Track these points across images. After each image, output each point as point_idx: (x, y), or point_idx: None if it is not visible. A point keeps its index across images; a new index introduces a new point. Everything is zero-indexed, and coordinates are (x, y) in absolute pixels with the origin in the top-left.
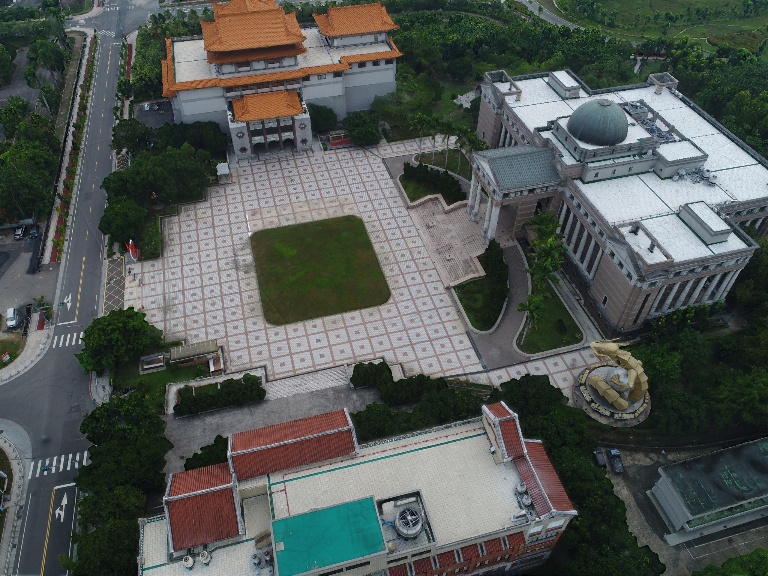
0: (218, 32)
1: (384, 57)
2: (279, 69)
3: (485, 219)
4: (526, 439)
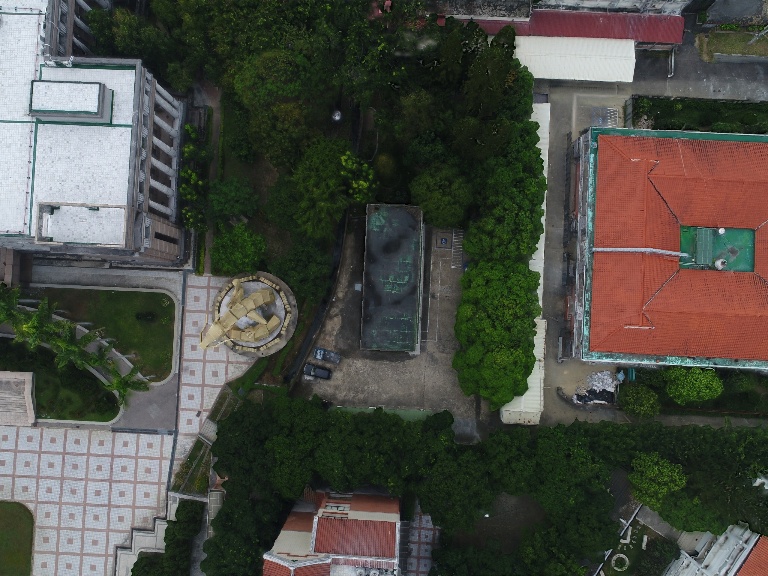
0: None
1: None
2: None
3: None
4: (313, 543)
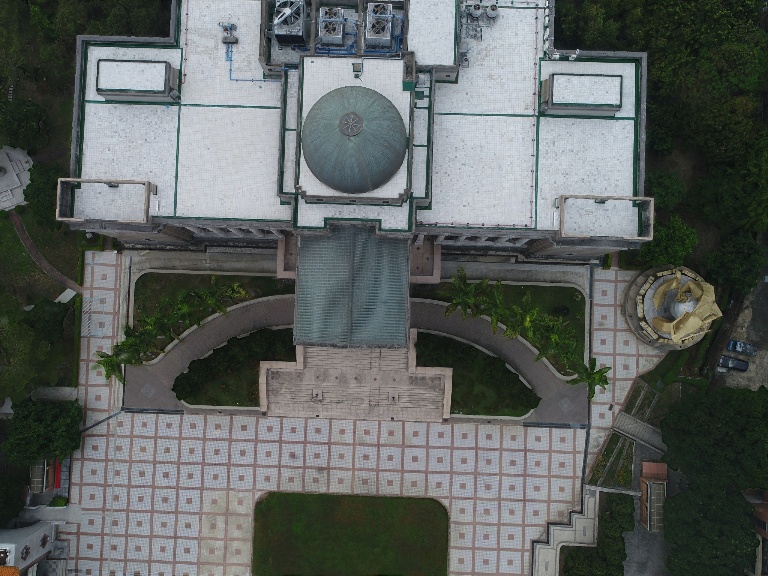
0: None
1: None
2: None
3: None
4: None
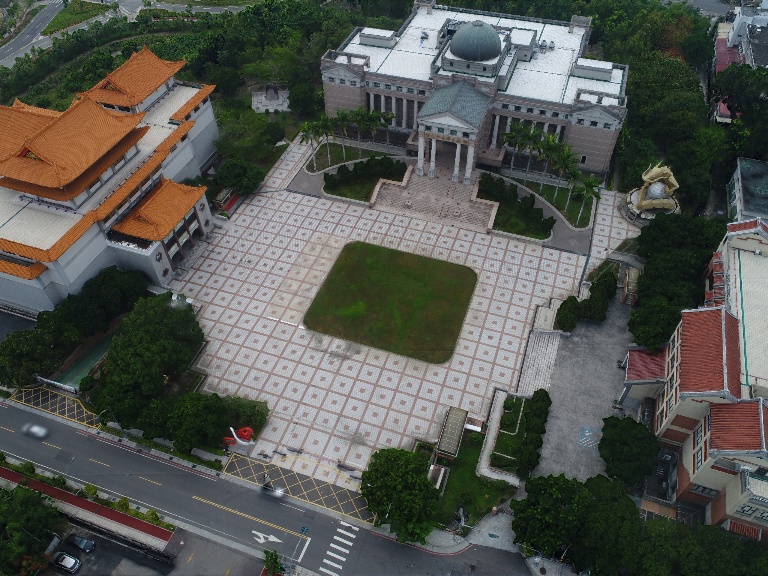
0: (47, 160)
1: (203, 97)
2: (129, 165)
3: (456, 166)
4: None
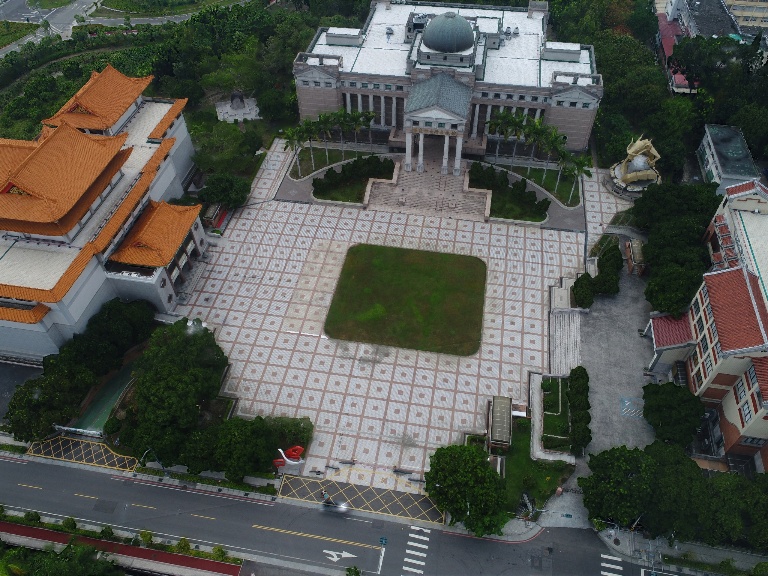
0: (36, 193)
1: (177, 112)
2: (116, 191)
3: (445, 158)
4: None
